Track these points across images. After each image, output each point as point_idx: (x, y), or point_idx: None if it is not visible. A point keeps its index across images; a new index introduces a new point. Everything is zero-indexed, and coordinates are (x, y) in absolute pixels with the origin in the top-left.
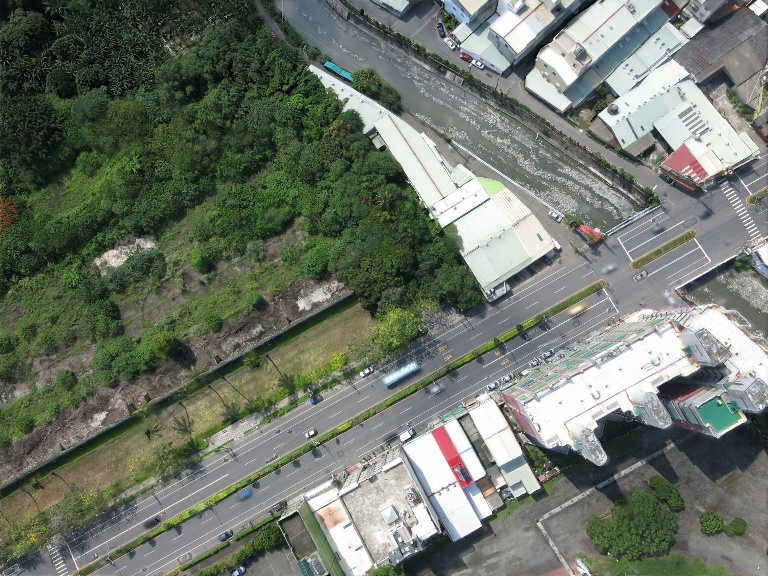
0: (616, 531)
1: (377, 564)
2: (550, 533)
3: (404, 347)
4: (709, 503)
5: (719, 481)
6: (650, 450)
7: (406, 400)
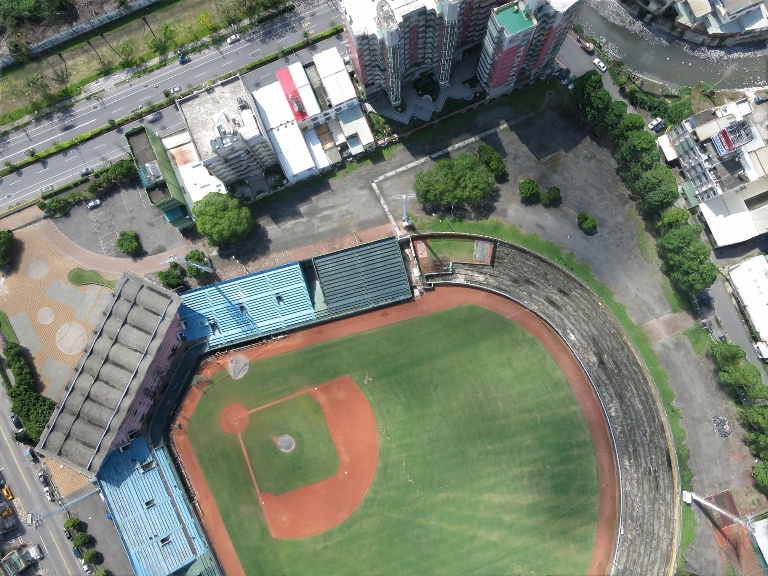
0: (435, 177)
1: (203, 161)
2: (383, 193)
3: (271, 21)
4: (531, 178)
5: (543, 159)
6: (484, 128)
7: (266, 67)
